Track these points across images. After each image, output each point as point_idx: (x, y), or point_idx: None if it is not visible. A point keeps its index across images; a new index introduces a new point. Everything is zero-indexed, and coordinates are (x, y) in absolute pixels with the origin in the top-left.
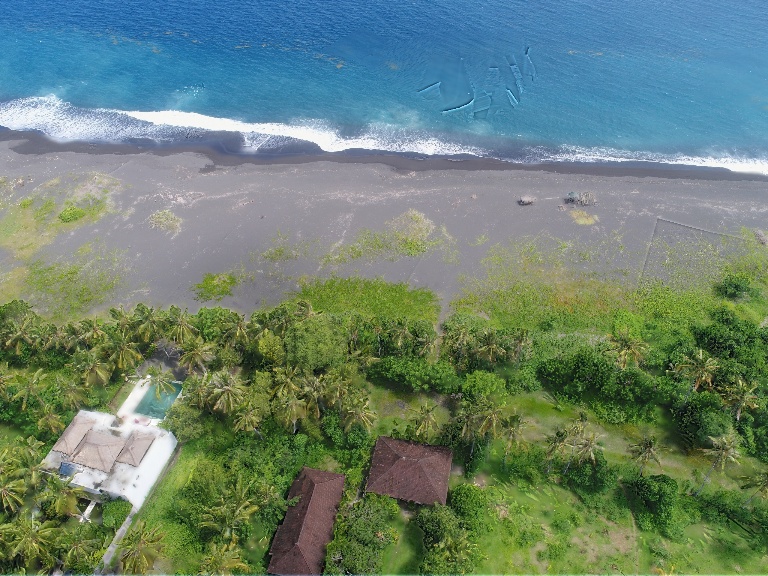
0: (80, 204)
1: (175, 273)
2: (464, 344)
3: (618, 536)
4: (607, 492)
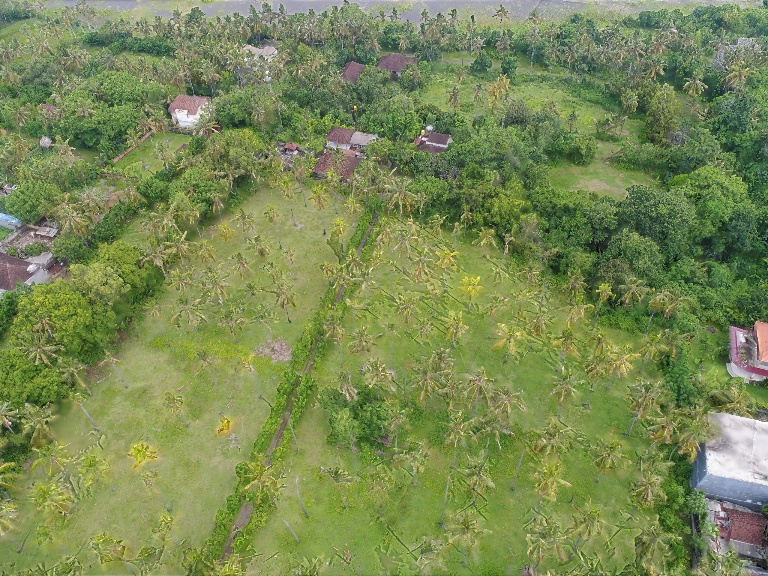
0: None
1: None
2: None
3: None
4: (489, 74)
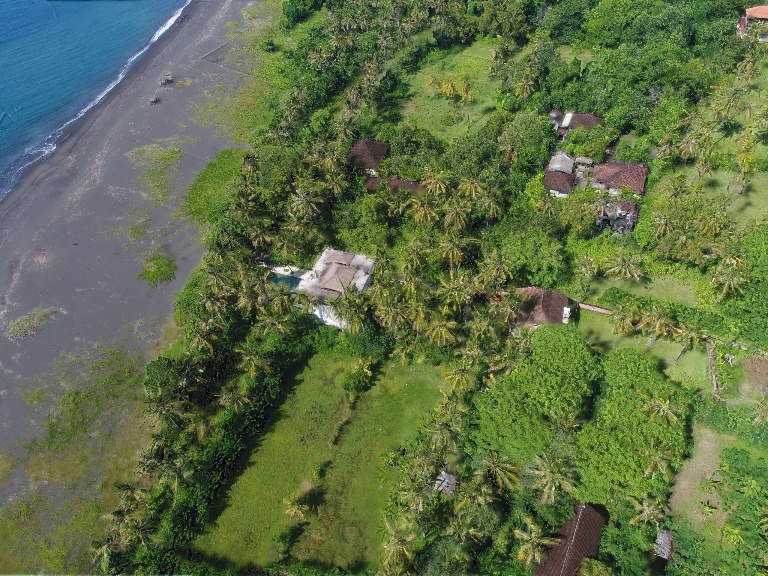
0: None
1: (124, 302)
2: None
3: (405, 104)
4: None
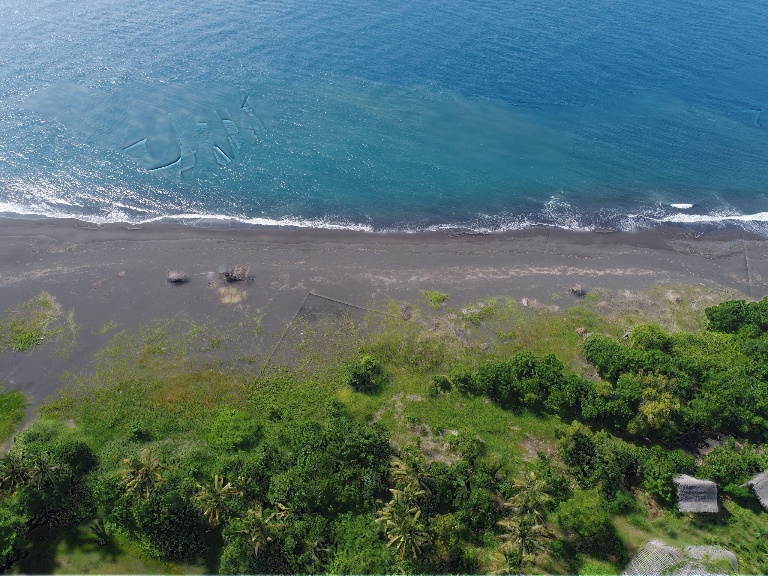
0: None
1: None
2: None
3: None
4: None
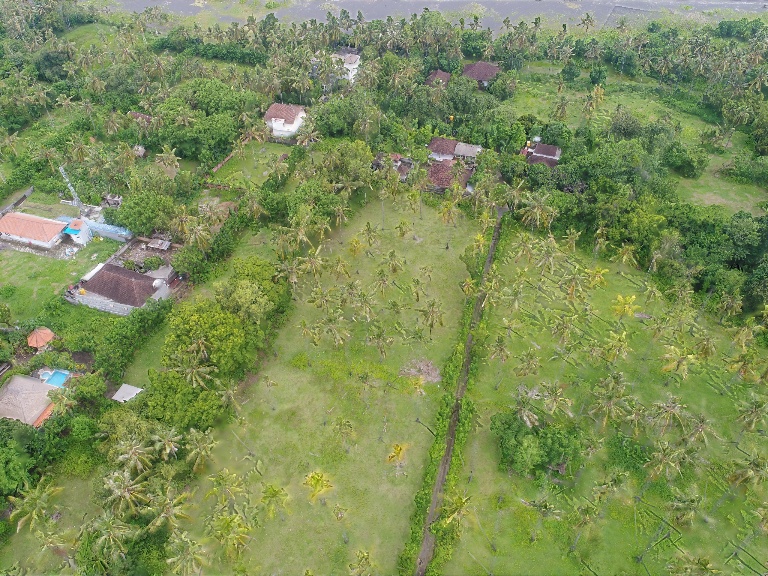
0: (276, 1)
1: None
2: (506, 40)
3: (580, 95)
4: (576, 84)
